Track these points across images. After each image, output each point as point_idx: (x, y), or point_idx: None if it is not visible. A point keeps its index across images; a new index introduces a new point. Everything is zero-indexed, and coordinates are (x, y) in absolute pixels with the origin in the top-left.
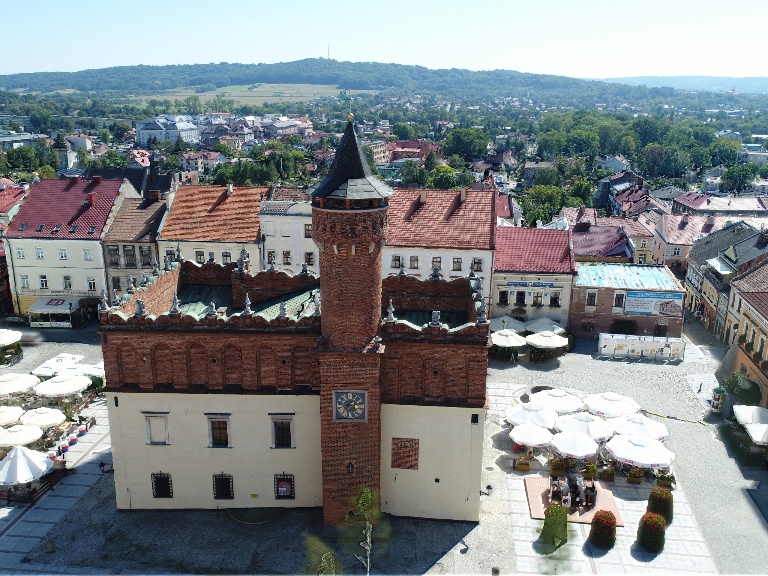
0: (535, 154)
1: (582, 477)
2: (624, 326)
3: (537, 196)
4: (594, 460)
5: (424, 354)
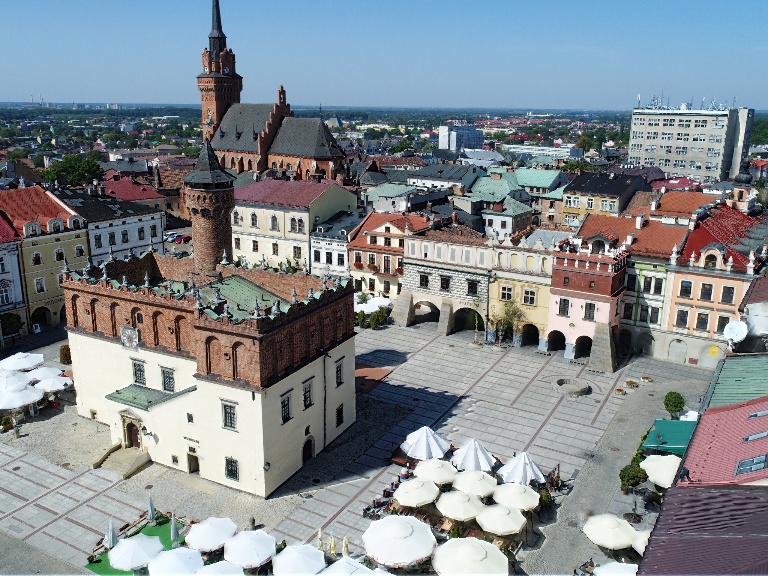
0: None
1: None
2: None
3: None
4: None
5: None
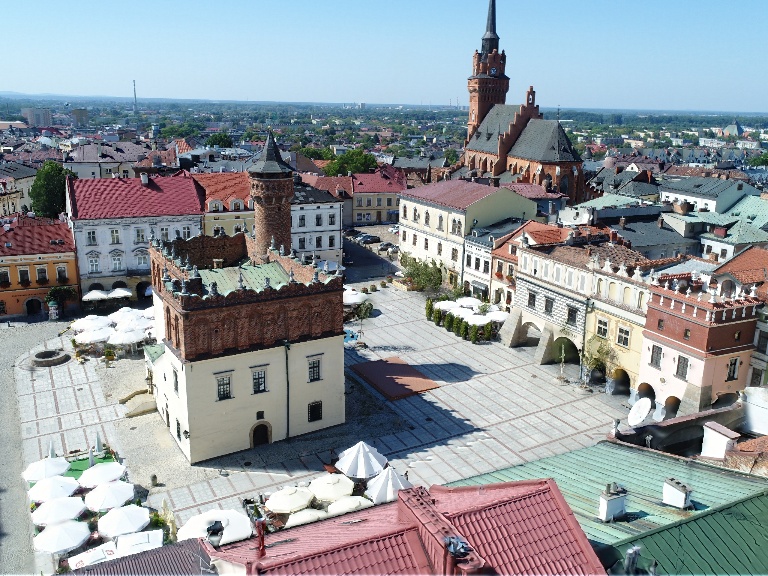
0: None
1: None
2: None
3: None
4: None
5: None
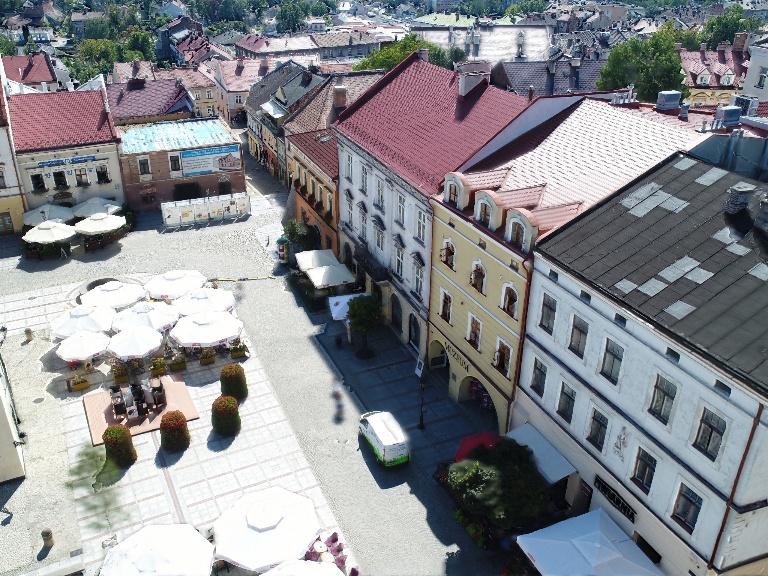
0: (83, 3)
1: (147, 378)
2: (187, 190)
3: (89, 53)
4: (161, 353)
5: None
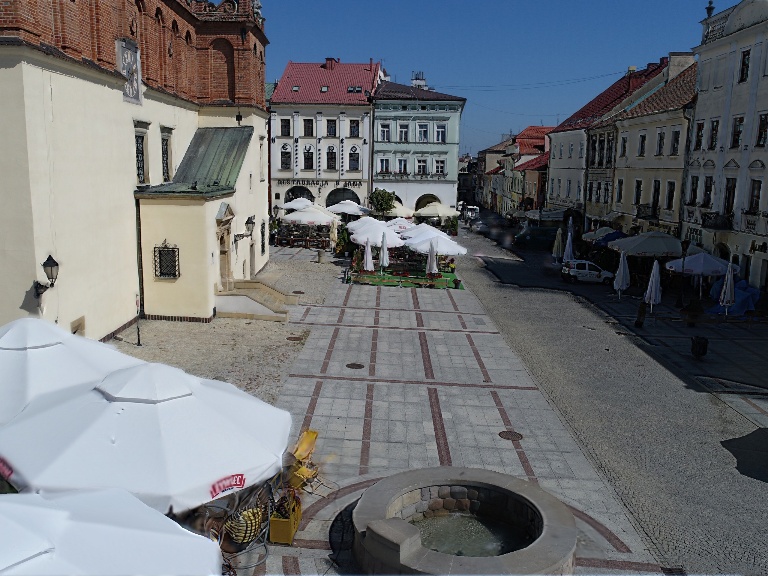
0: None
1: None
2: None
3: None
4: None
5: None
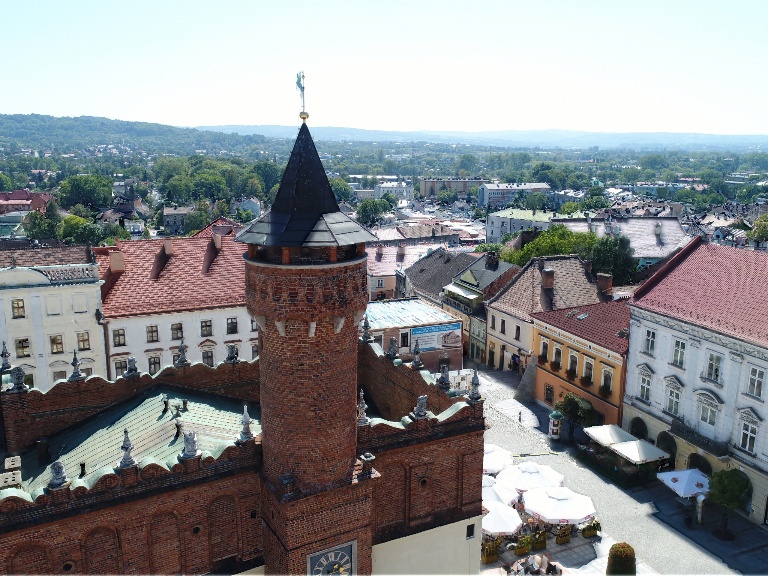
0: (165, 200)
1: (532, 557)
2: None
3: None
4: (519, 530)
5: (409, 461)
